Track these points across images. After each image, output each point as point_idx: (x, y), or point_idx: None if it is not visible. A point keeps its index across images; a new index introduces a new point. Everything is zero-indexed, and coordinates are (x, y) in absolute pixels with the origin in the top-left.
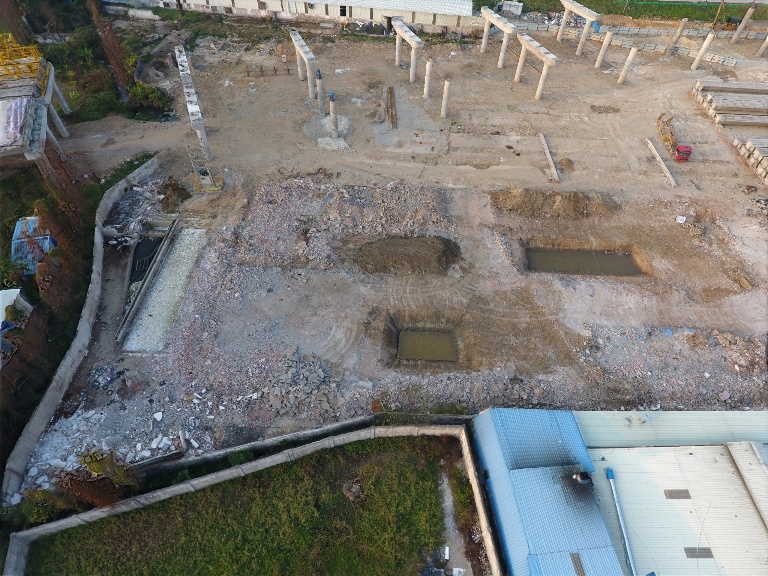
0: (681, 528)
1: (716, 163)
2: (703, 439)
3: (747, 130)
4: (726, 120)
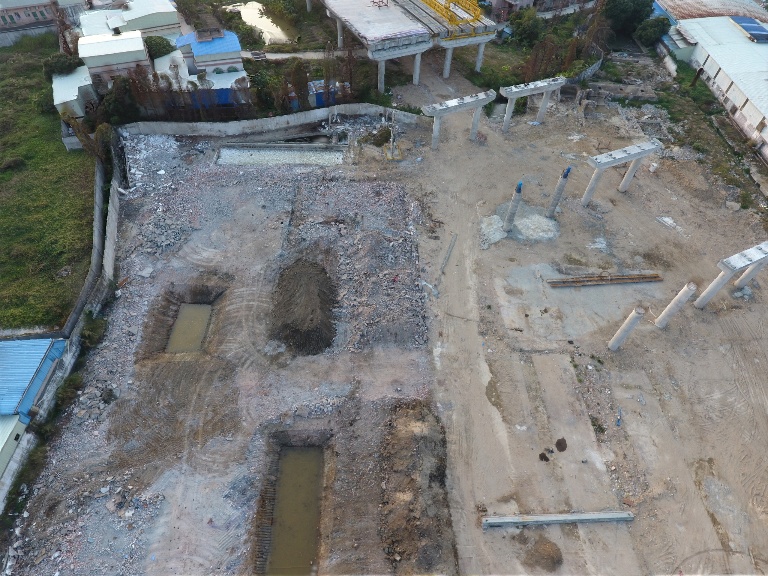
0: None
1: None
2: None
3: None
4: None
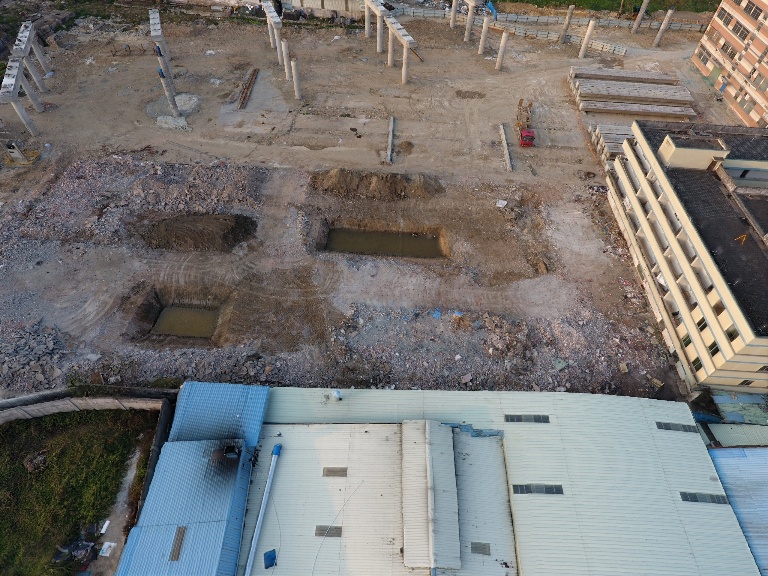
0: (323, 506)
1: (563, 149)
2: (392, 418)
3: (610, 118)
4: (587, 107)
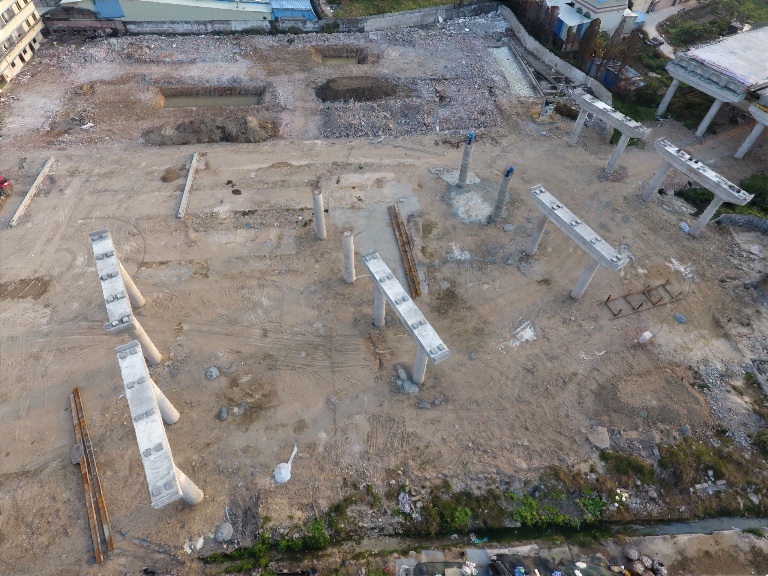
0: None
1: None
2: (212, 2)
3: None
4: None
